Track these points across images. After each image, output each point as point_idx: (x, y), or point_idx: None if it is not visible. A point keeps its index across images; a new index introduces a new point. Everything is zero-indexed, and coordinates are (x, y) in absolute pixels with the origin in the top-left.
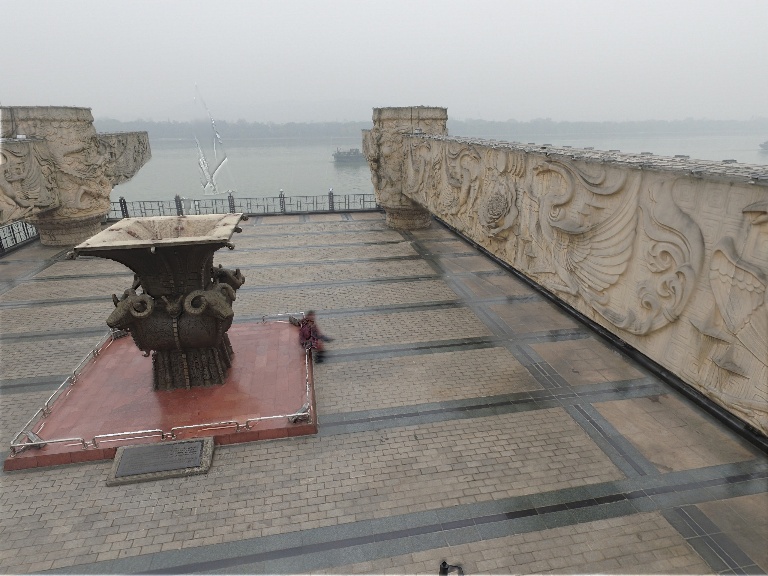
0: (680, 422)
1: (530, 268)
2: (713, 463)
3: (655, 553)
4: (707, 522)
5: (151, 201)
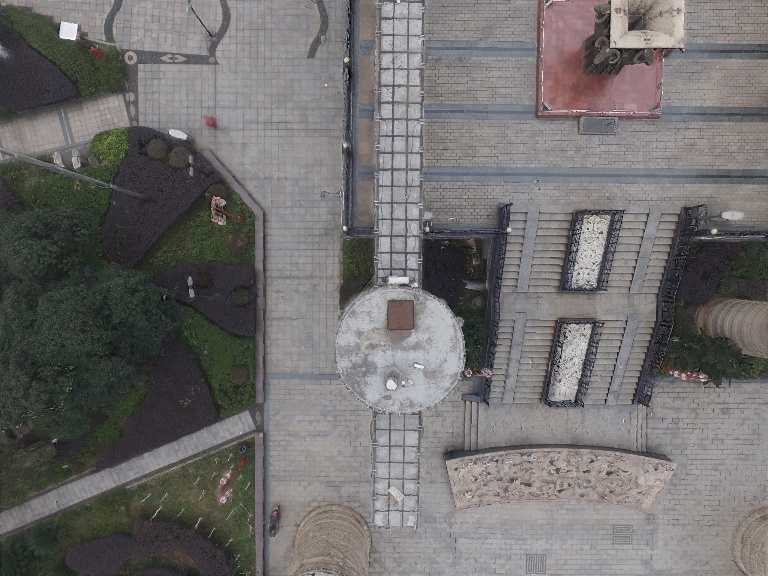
0: None
1: None
2: None
3: (759, 199)
4: None
5: None
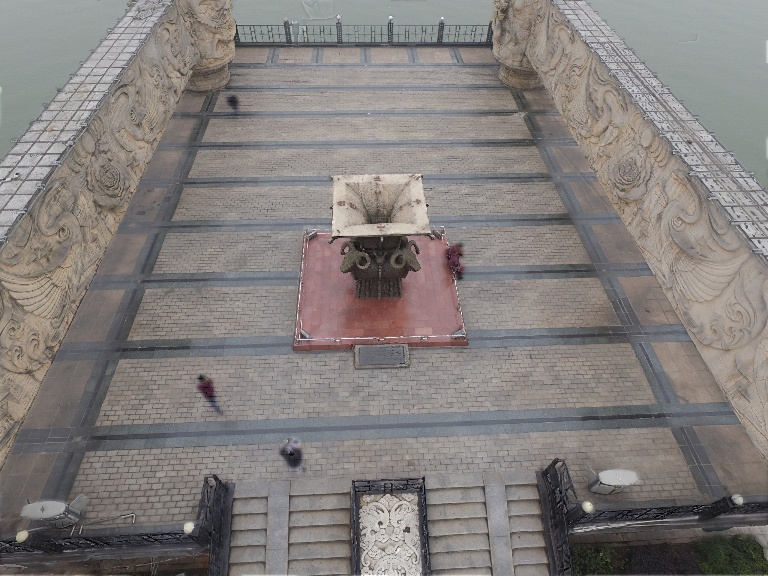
0: None
1: (640, 241)
2: (716, 401)
3: (659, 451)
4: (695, 438)
5: (261, 25)
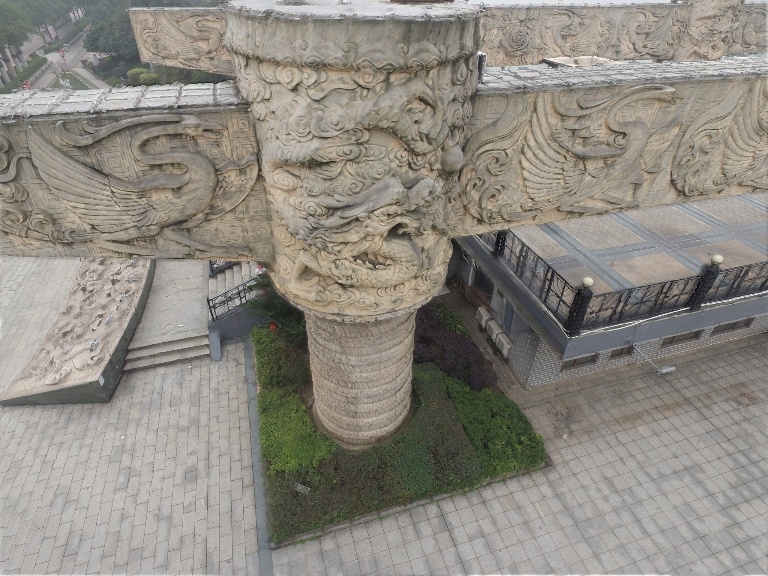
0: None
1: None
2: (634, 283)
3: None
4: (573, 266)
5: None
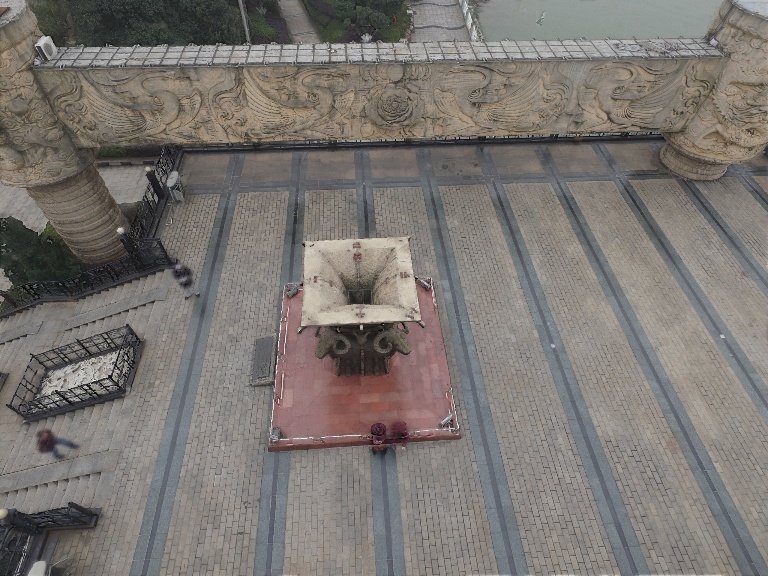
0: None
1: None
2: None
3: None
4: None
5: None
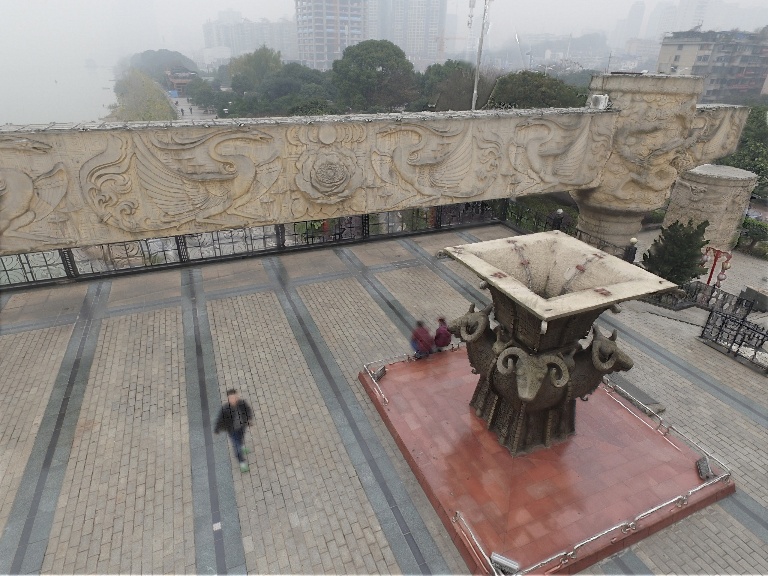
0: (436, 240)
1: (388, 204)
2: None
3: None
4: None
5: None
